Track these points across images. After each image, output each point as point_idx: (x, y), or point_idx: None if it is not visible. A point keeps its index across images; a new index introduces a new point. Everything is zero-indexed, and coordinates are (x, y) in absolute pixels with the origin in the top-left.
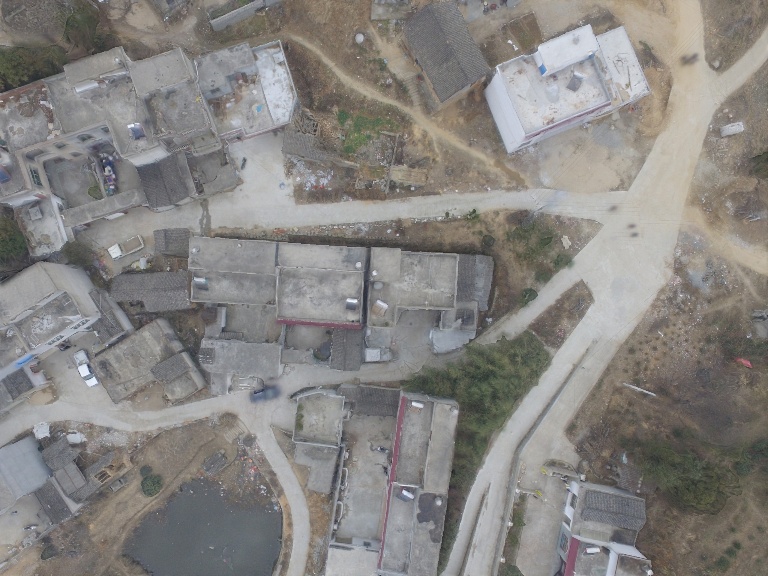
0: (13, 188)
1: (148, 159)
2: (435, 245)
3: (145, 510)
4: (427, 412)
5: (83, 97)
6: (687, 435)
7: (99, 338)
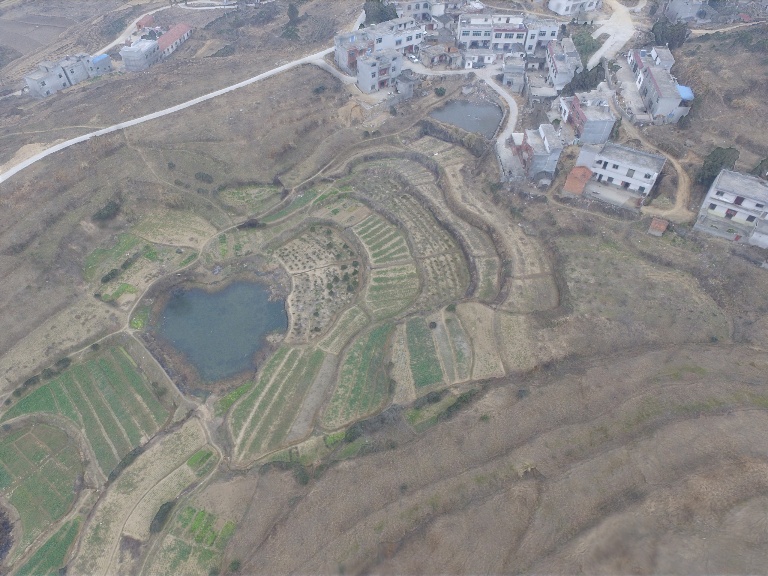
0: None
1: (437, 13)
2: None
3: (435, 105)
4: (559, 46)
5: None
6: None
7: (421, 46)
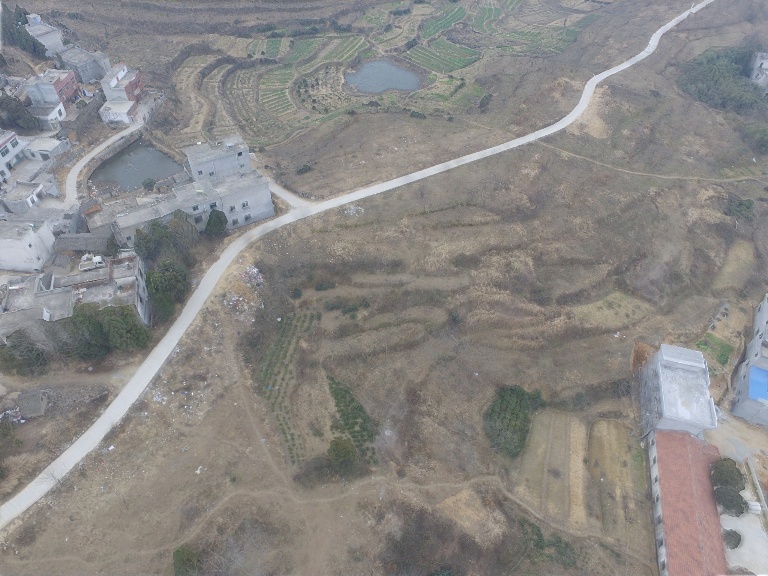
0: (125, 266)
1: None
2: None
3: None
4: None
5: (48, 312)
6: None
7: None
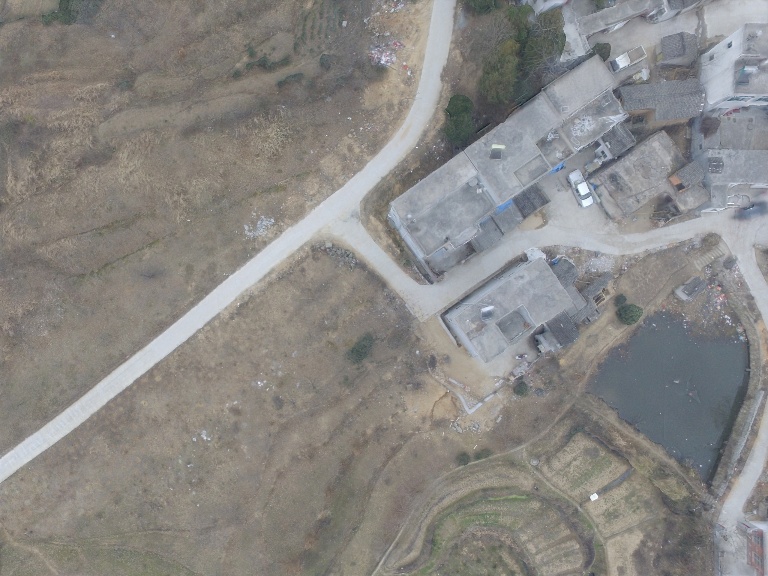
0: None
1: None
2: None
3: (609, 345)
4: None
5: None
6: None
7: (609, 150)
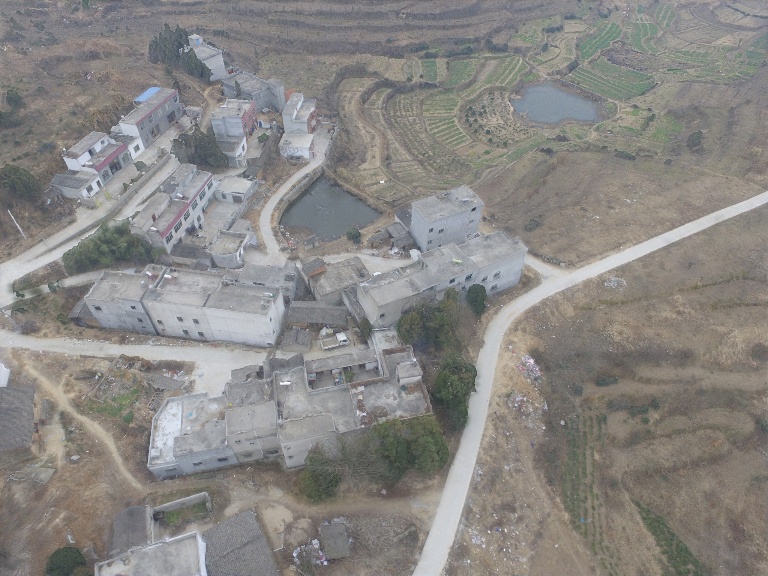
0: (398, 357)
1: None
2: (105, 331)
3: None
4: None
5: None
6: (6, 204)
7: None
